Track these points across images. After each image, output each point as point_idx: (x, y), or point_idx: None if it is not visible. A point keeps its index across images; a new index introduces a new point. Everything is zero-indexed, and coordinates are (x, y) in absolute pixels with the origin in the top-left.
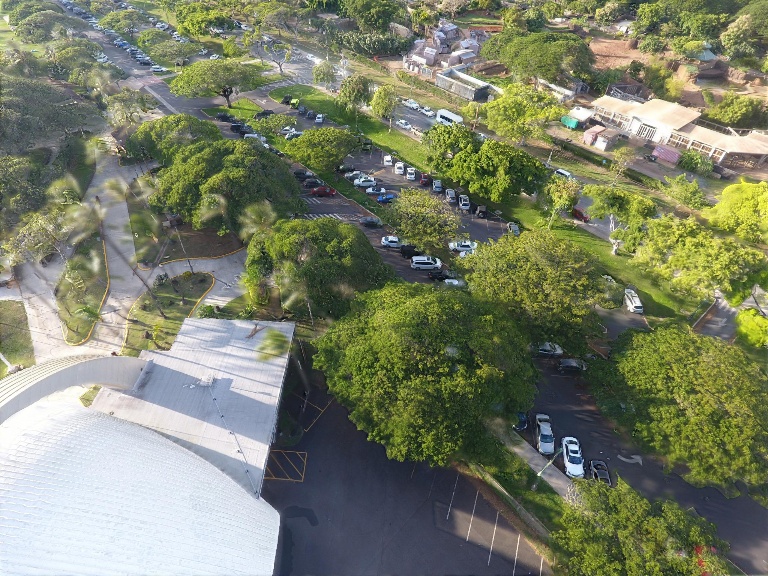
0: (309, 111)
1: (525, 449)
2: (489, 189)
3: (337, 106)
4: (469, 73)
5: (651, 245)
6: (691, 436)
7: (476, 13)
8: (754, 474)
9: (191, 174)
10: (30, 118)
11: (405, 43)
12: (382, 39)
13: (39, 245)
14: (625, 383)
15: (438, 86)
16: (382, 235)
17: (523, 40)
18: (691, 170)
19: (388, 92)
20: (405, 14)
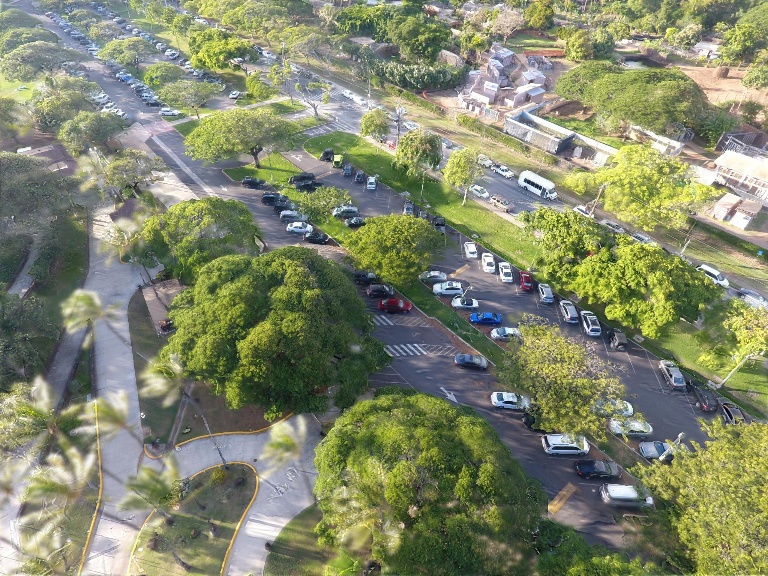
0: (358, 173)
1: None
2: (639, 318)
3: (394, 168)
4: (540, 114)
5: None
6: None
7: (527, 33)
8: None
9: (223, 321)
10: None
11: (458, 75)
12: (433, 71)
13: None
14: None
15: (508, 133)
16: (488, 385)
17: (616, 78)
18: None
19: (469, 159)
20: (451, 37)
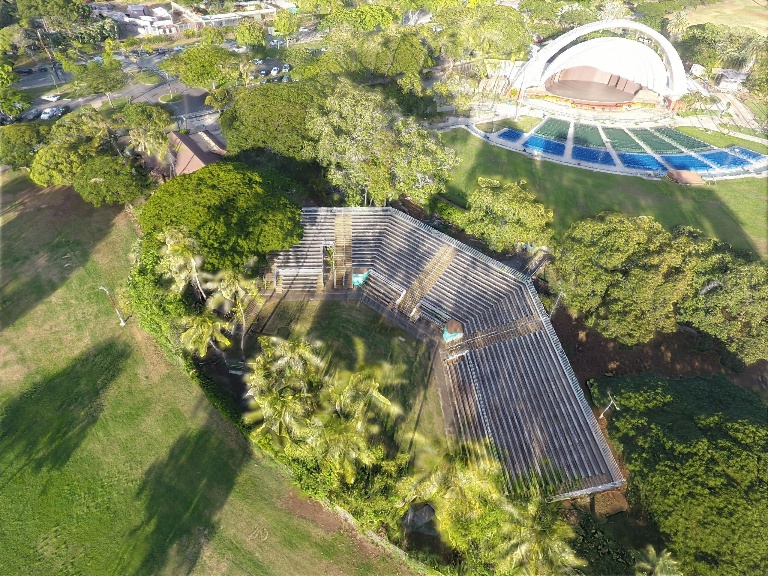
0: None
1: None
2: None
3: (253, 48)
4: None
5: (443, 1)
6: None
7: None
8: None
9: None
10: None
11: None
12: (113, 22)
13: None
14: None
15: None
16: None
17: None
18: (347, 5)
19: None
20: None
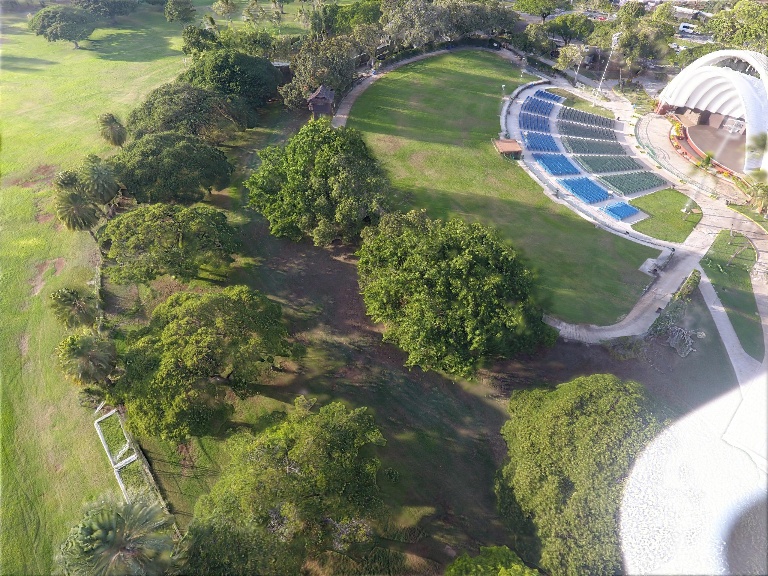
0: None
1: None
2: (763, 46)
3: None
4: None
5: None
6: None
7: None
8: None
9: (628, 31)
10: (511, 11)
11: None
12: None
13: (578, 58)
14: None
15: None
16: None
17: None
18: None
19: (670, 6)
20: None
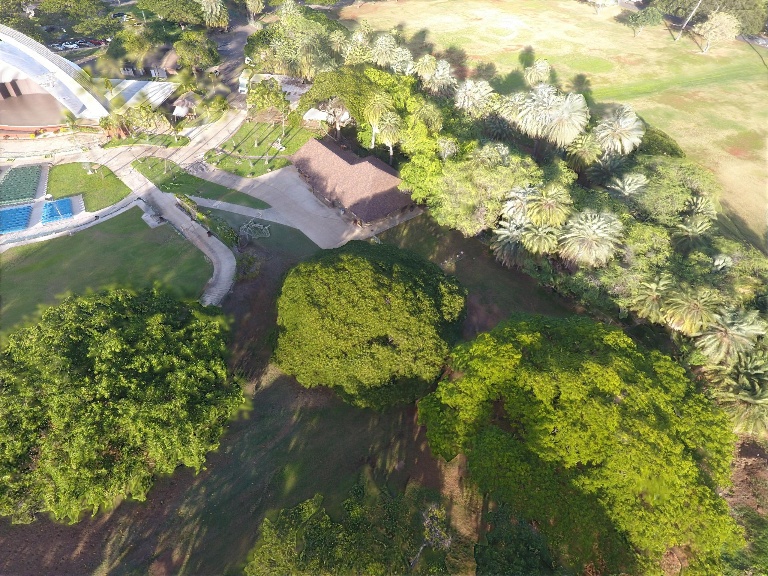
0: None
1: (58, 52)
2: None
3: None
4: None
5: None
6: (79, 7)
7: None
8: (99, 8)
9: None
10: None
11: None
12: None
13: None
14: (52, 13)
15: None
16: None
17: None
18: None
19: None
20: None
